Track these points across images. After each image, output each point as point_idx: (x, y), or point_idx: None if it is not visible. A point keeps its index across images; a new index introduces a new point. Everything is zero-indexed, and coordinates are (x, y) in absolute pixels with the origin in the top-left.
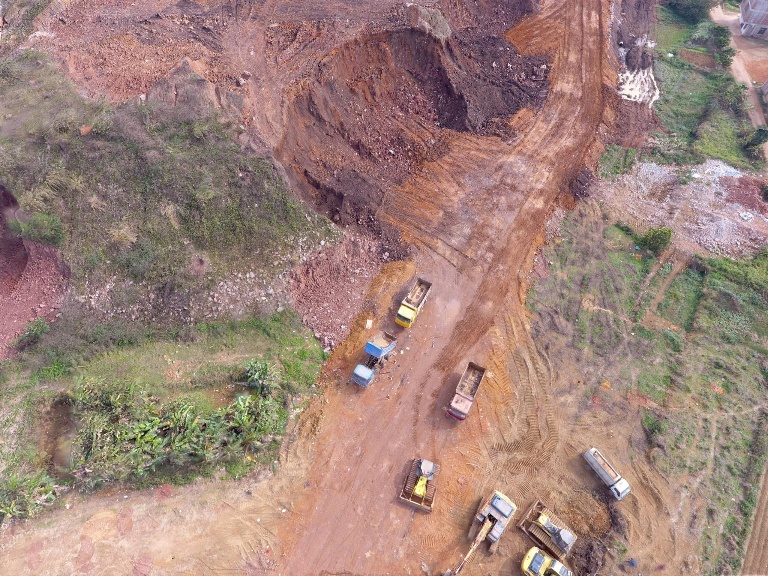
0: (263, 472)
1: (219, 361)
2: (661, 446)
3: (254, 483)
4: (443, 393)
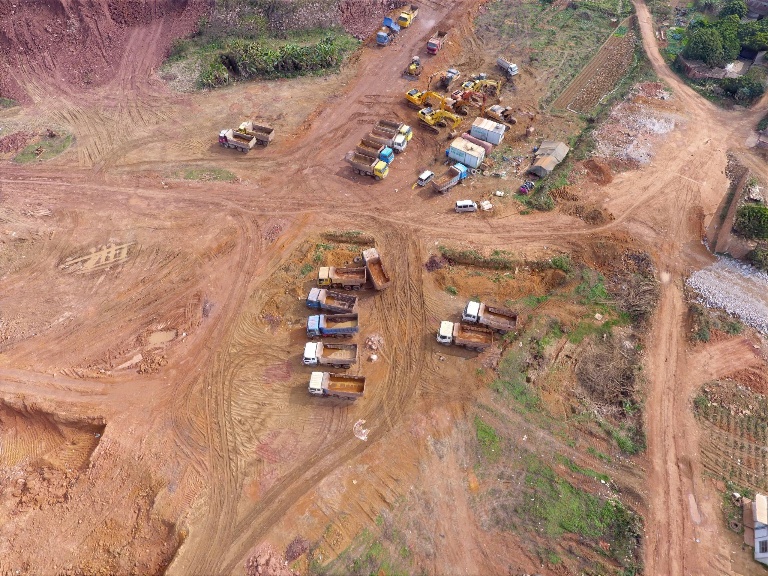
0: (332, 74)
1: (301, 46)
2: (537, 59)
3: (328, 77)
4: (425, 48)
